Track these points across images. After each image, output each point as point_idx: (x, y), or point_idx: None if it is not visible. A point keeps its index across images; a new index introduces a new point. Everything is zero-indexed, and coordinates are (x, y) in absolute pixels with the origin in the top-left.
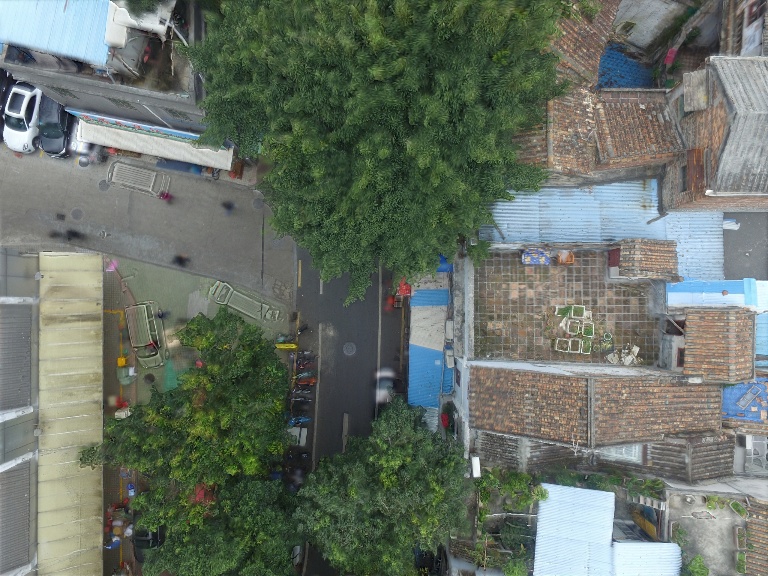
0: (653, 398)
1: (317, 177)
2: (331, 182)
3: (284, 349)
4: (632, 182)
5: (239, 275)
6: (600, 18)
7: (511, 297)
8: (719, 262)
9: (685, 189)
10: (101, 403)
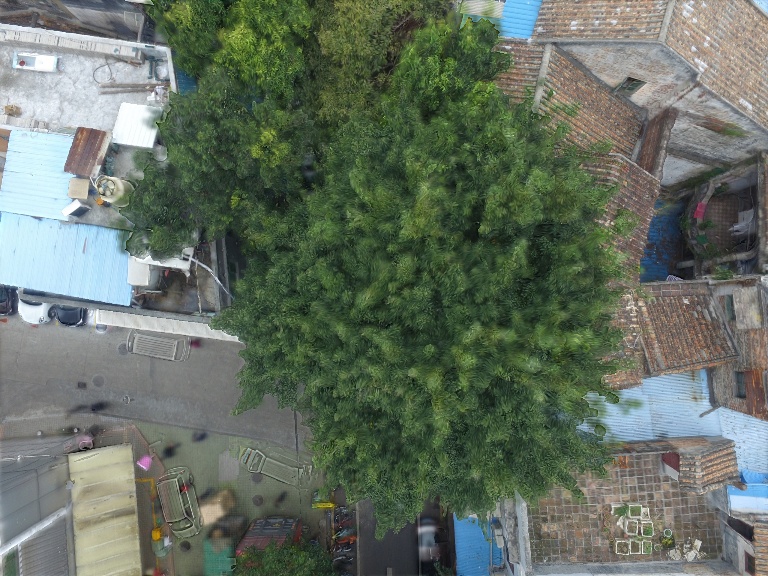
0: None
1: (371, 472)
2: (383, 459)
3: None
4: (680, 373)
5: (268, 431)
6: None
7: (563, 497)
8: None
9: (741, 395)
10: None
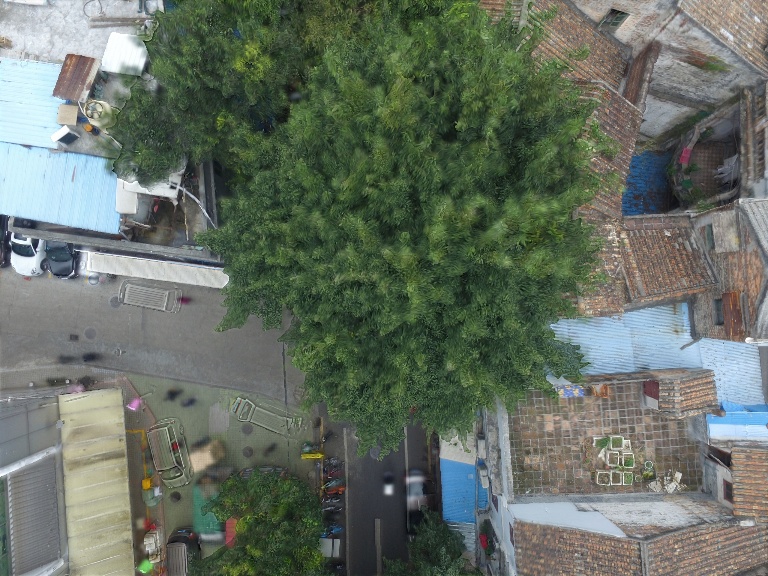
0: (706, 546)
1: (351, 377)
2: (364, 370)
3: (310, 458)
4: (662, 307)
5: (258, 384)
6: (619, 153)
7: (546, 429)
8: (757, 382)
9: (720, 323)
10: (131, 541)
